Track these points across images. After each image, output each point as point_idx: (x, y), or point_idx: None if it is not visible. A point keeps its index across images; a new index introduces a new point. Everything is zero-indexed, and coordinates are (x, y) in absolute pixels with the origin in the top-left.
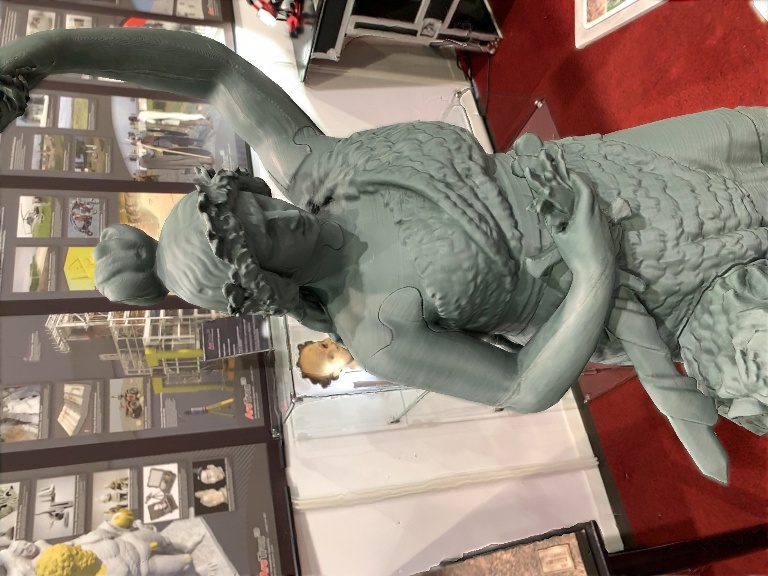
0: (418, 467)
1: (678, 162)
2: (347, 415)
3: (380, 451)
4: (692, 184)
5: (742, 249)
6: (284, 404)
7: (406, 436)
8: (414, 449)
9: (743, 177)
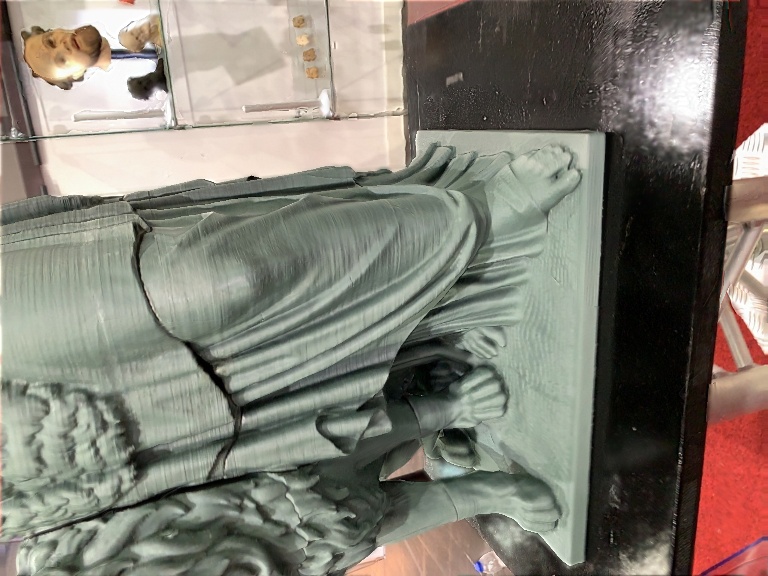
0: (204, 167)
1: (7, 378)
2: (116, 107)
3: (158, 149)
4: (4, 432)
5: (64, 515)
6: (31, 90)
7: (190, 135)
8: (200, 148)
9: (132, 382)
